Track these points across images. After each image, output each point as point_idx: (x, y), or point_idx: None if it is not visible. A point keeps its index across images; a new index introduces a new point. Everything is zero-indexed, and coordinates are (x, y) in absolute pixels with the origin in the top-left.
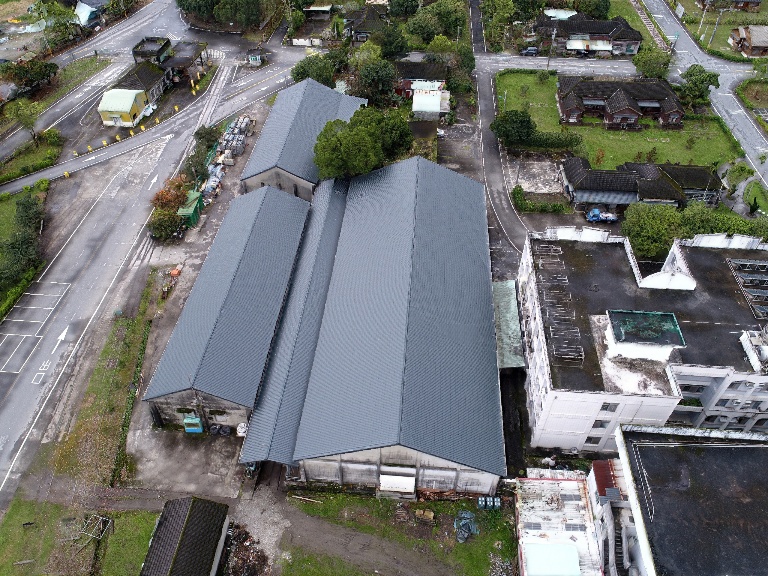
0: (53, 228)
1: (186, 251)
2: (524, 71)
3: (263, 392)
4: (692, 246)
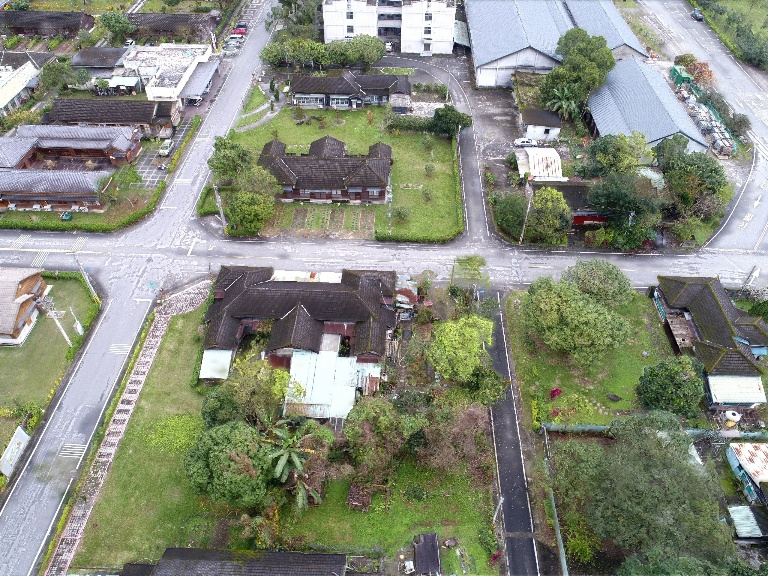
0: (767, 78)
1: (660, 66)
2: (422, 237)
3: (564, 5)
4: (366, 8)
